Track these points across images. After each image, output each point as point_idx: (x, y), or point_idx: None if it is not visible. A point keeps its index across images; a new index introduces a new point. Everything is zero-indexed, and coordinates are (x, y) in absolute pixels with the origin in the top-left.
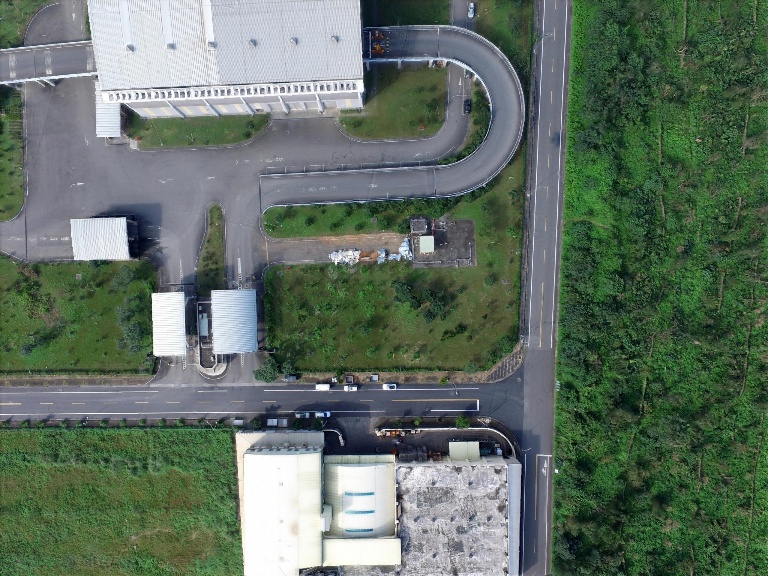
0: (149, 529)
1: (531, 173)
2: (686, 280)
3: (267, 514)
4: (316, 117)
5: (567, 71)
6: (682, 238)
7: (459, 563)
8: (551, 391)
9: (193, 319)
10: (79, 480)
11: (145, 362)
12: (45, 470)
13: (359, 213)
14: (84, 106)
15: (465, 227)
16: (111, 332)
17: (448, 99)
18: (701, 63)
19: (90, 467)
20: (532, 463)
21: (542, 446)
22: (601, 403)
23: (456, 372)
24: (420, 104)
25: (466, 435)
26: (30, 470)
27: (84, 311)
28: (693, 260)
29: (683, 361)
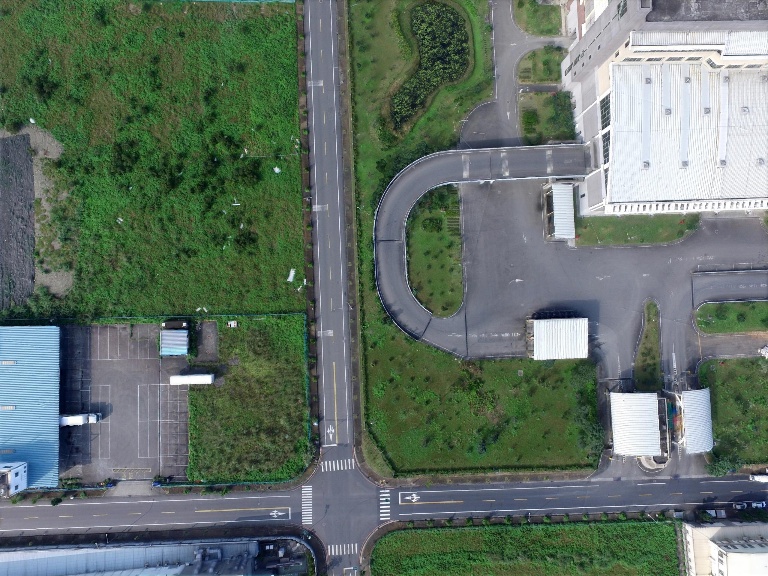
0: None
1: None
2: None
3: None
4: (742, 217)
5: None
6: None
7: None
8: None
9: None
10: None
11: (590, 457)
12: (490, 568)
13: None
14: (521, 204)
15: None
16: (553, 428)
17: None
18: None
19: (536, 564)
20: None
21: None
22: None
23: None
24: None
25: None
26: (474, 569)
27: (526, 407)
28: None
29: None
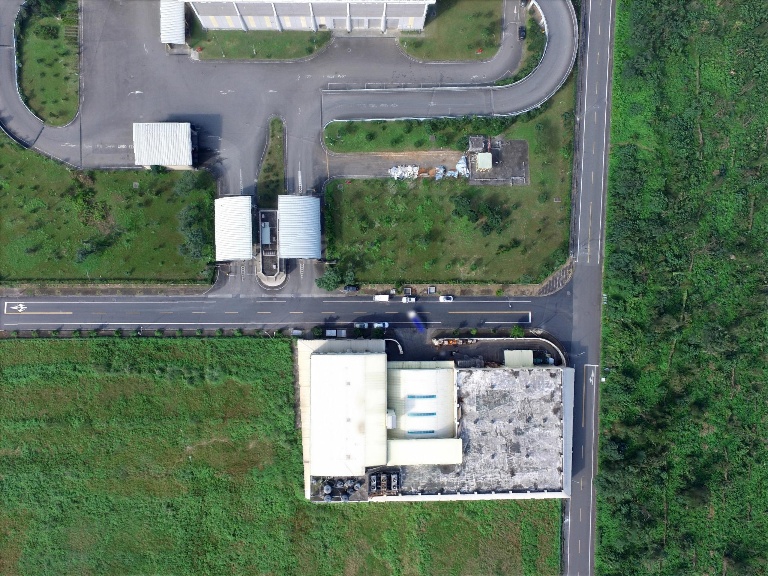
0: (205, 439)
1: (581, 98)
2: (721, 202)
3: (334, 413)
4: (377, 37)
5: (614, 5)
6: (717, 163)
7: (516, 463)
8: (598, 304)
9: (255, 228)
10: (132, 390)
11: (204, 271)
12: (97, 380)
13: (418, 131)
14: (144, 15)
15: (519, 147)
16: (168, 241)
17: (504, 25)
18: (737, 1)
19: (144, 377)
20: (580, 373)
21: (590, 356)
22: (645, 314)
23: (510, 285)
24: (478, 29)
25: (519, 346)
26: (81, 380)
27: (141, 220)
28: (727, 183)
29: (719, 276)
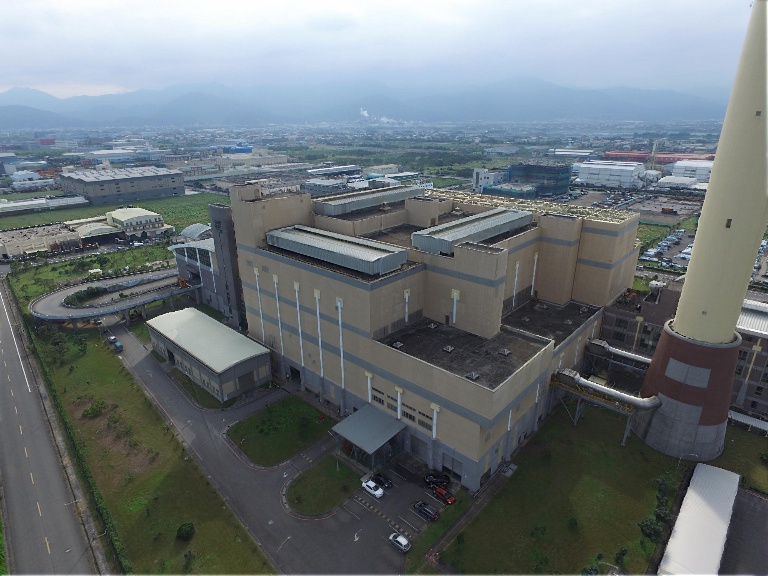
0: None
1: None
2: None
3: None
4: None
5: None
6: None
7: None
8: None
9: None
10: None
11: None
12: None
13: None
14: None
15: None
16: None
17: None
18: None
19: None
20: None
21: None
22: None
23: None
24: None
25: None
26: None
27: None
28: None
29: None
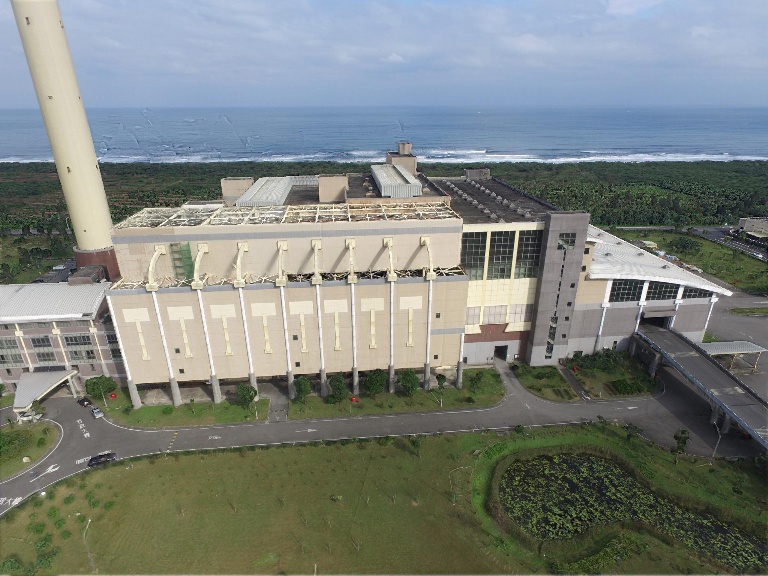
0: None
1: None
2: None
3: None
4: None
5: None
6: None
7: None
8: None
9: None
10: None
11: None
12: None
13: None
14: None
15: None
16: None
17: None
18: None
19: None
20: None
21: None
22: None
23: None
24: None
25: None
26: None
27: None
28: None
29: None
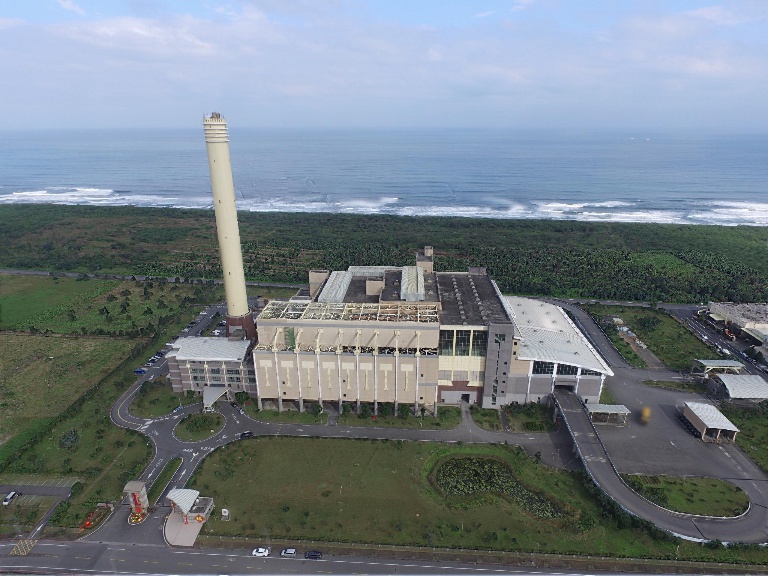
0: None
1: None
2: None
3: None
4: None
5: None
6: None
7: None
8: None
9: None
10: None
11: None
12: None
13: None
14: (605, 437)
15: None
16: None
17: None
18: None
19: None
20: None
21: None
22: None
23: None
24: None
25: None
26: None
27: None
28: None
29: None
